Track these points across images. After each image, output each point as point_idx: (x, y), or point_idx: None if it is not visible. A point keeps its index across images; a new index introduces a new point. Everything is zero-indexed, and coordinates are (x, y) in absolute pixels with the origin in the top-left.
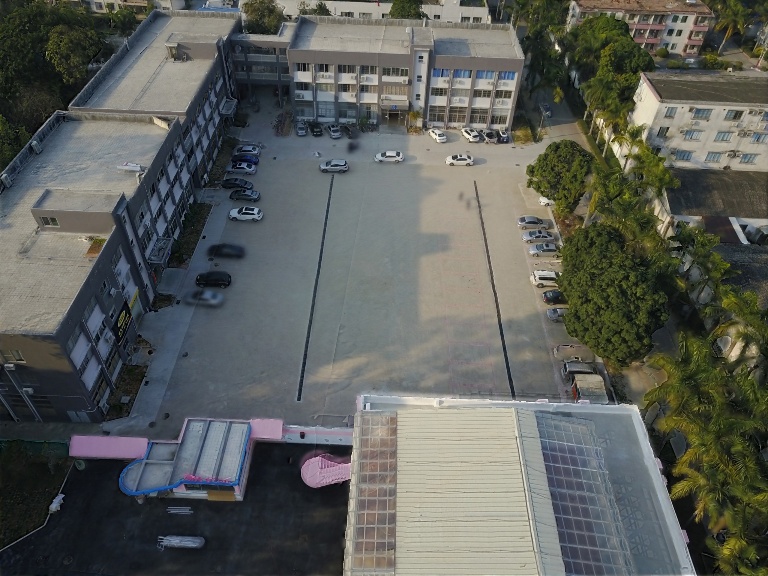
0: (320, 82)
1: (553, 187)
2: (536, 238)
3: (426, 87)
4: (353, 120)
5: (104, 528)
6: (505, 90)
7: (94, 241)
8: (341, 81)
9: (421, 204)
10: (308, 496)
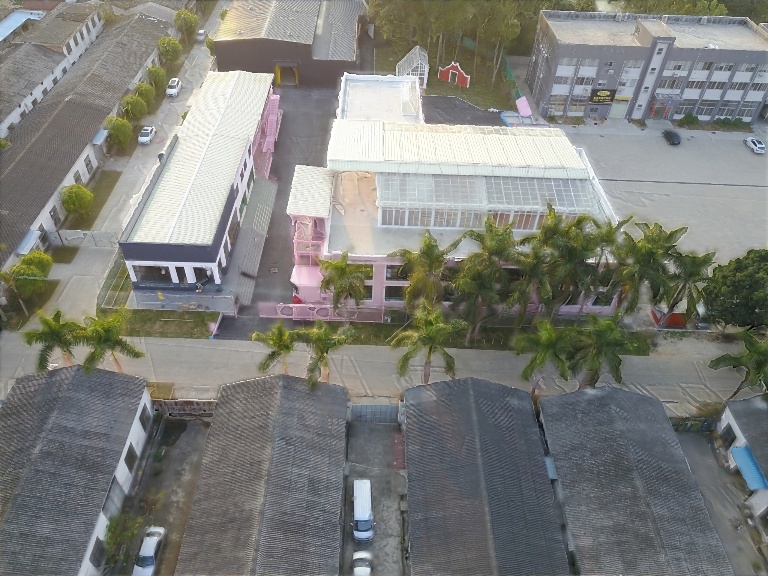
0: None
1: None
2: None
3: None
4: None
5: (486, 124)
6: None
7: None
8: None
9: None
10: None
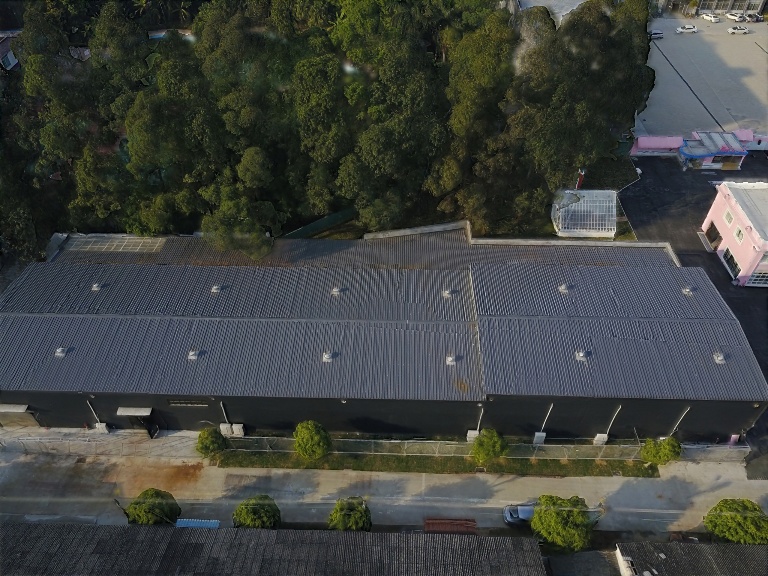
0: None
1: None
2: None
3: None
4: None
5: (674, 179)
6: None
7: None
8: None
9: (729, 54)
10: None
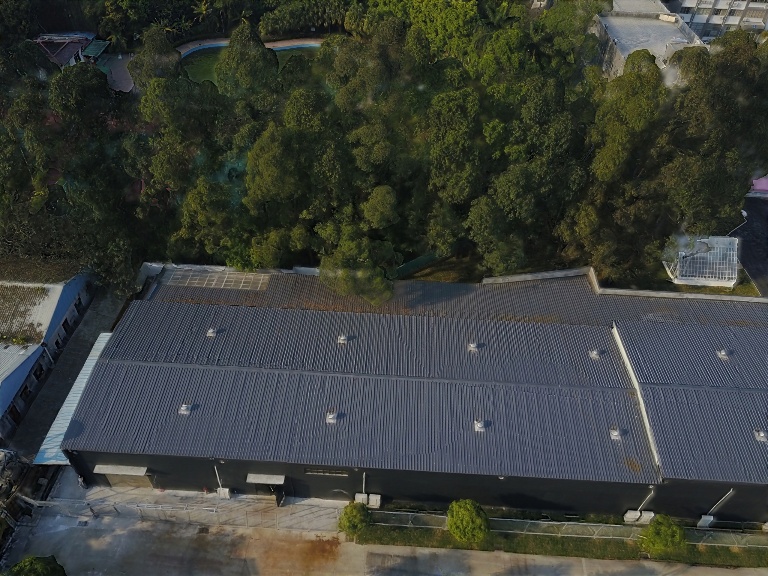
0: (701, 7)
1: None
2: None
3: None
4: None
5: None
6: None
7: None
8: (717, 6)
9: None
10: None
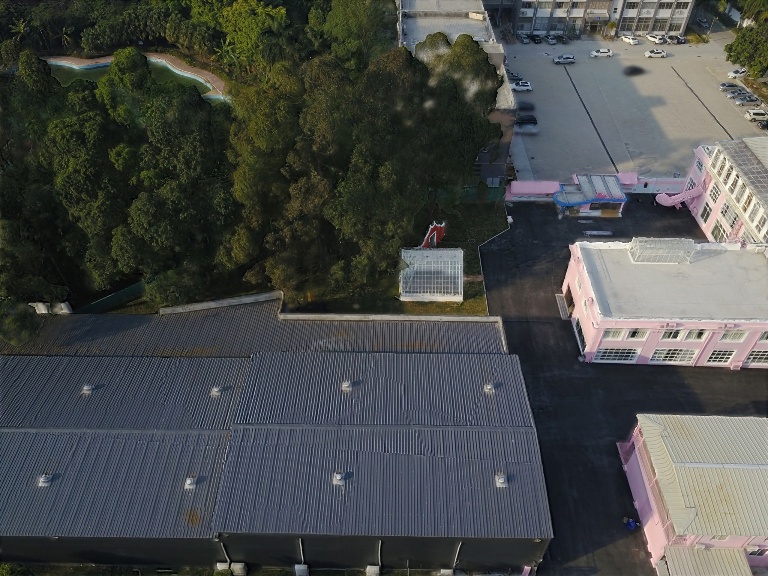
0: (542, 1)
1: (751, 56)
2: (738, 95)
3: (624, 1)
4: (561, 32)
5: (546, 229)
6: (684, 2)
7: None
8: None
9: (641, 80)
10: (662, 215)
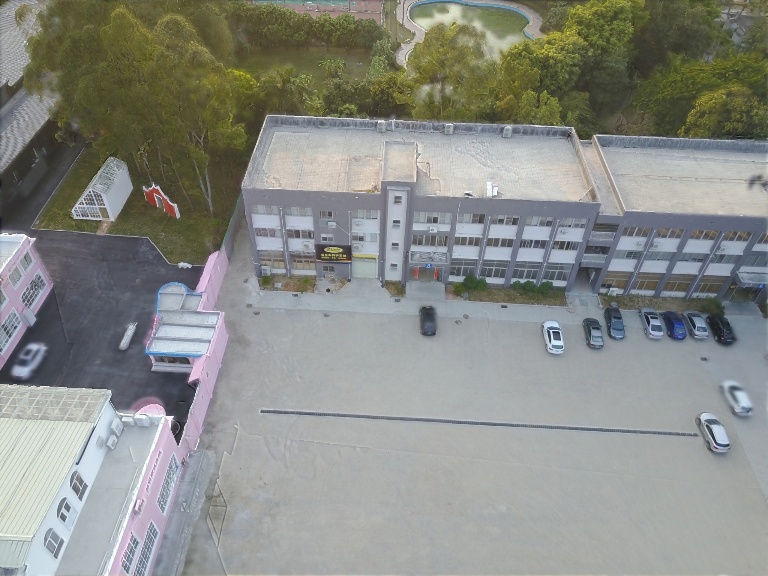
0: None
1: None
2: None
3: None
4: None
5: (157, 293)
6: None
7: (370, 190)
8: None
9: (665, 572)
10: None
